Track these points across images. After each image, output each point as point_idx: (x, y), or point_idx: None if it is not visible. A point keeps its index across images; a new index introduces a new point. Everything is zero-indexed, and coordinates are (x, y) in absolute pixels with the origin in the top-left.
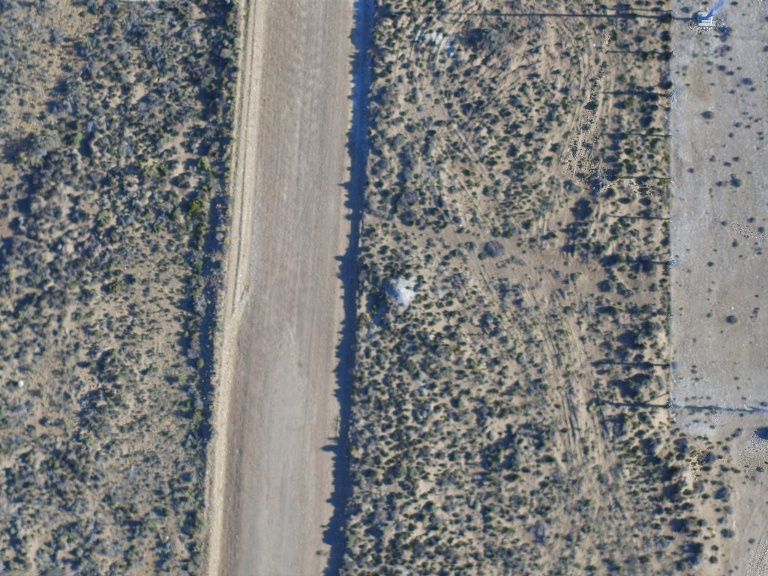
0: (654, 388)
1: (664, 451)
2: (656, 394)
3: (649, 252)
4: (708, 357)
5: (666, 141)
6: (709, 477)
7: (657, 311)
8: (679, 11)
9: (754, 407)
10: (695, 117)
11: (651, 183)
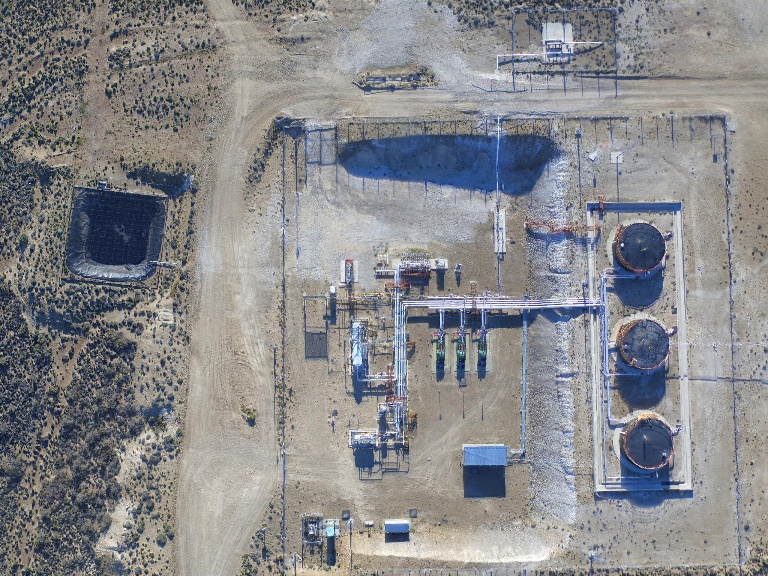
0: (735, 572)
1: (758, 567)
2: (737, 571)
3: (684, 575)
4: (721, 550)
5: (641, 569)
6: (765, 549)
7: (706, 571)
8: (589, 565)
9: (738, 532)
10: (630, 557)
11: (658, 575)
